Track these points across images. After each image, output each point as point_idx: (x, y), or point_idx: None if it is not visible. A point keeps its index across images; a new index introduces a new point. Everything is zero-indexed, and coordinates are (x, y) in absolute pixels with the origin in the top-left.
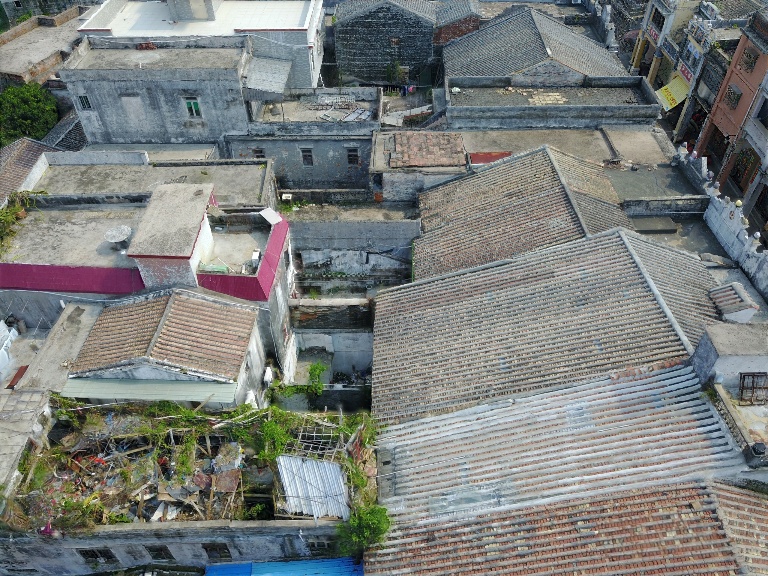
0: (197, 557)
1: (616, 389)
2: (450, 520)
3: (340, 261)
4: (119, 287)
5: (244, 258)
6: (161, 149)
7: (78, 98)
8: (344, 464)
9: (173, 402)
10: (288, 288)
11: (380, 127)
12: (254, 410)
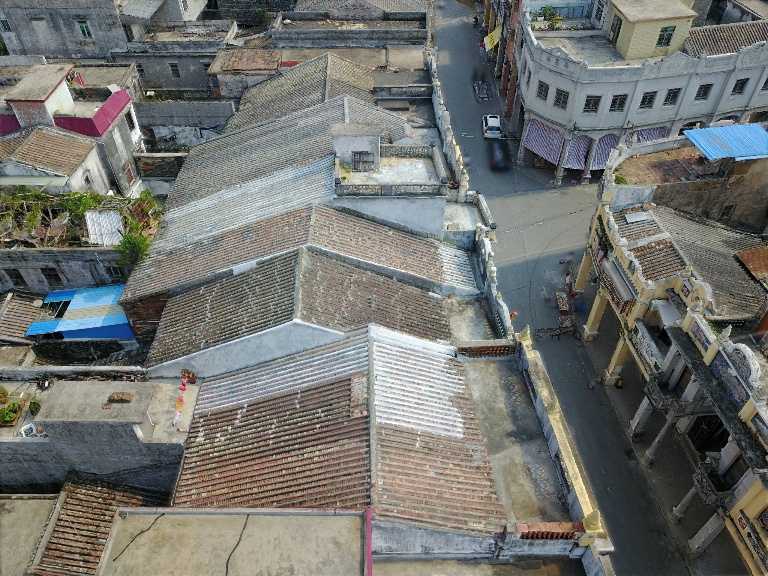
0: (41, 284)
1: (294, 172)
2: (183, 244)
3: (182, 136)
4: (4, 128)
5: (93, 114)
6: (64, 62)
7: (1, 22)
8: (122, 213)
9: (28, 187)
10: (133, 145)
11: (225, 46)
12: None
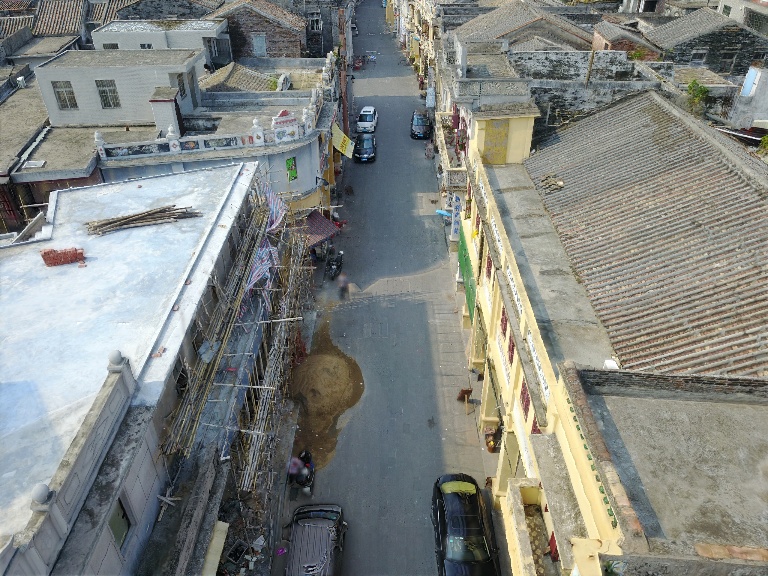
0: None
1: None
2: None
3: None
4: None
5: None
6: None
7: None
8: None
9: None
10: None
11: None
12: None
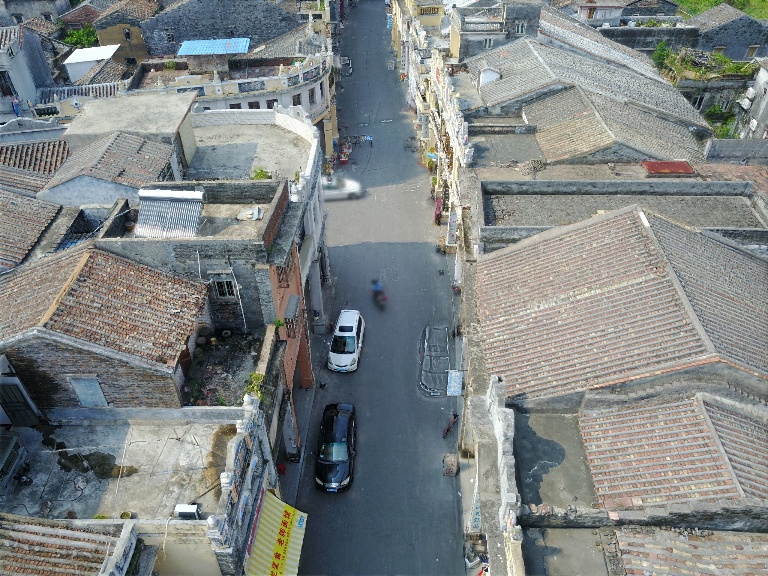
0: None
1: None
2: None
3: None
4: None
5: None
6: None
7: None
8: None
9: None
10: None
11: None
12: (742, 70)
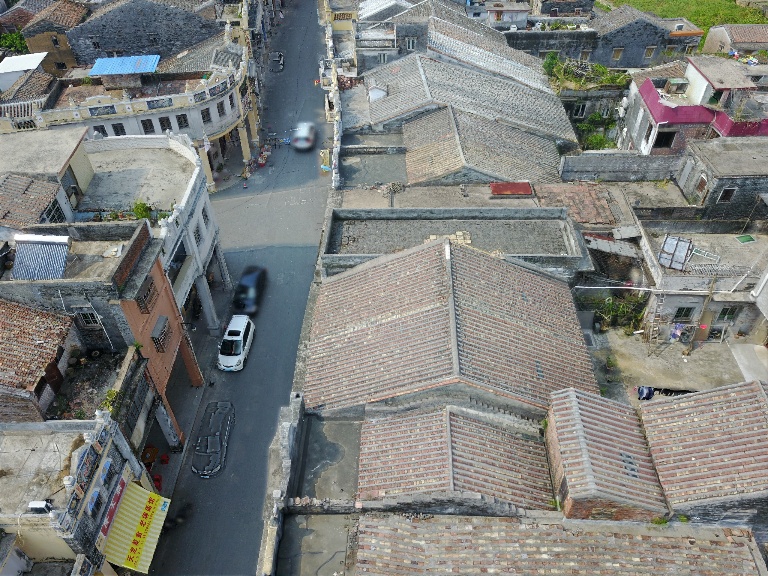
0: None
1: None
2: None
3: None
4: None
5: None
6: None
7: None
8: None
9: None
10: None
11: None
12: (617, 81)
